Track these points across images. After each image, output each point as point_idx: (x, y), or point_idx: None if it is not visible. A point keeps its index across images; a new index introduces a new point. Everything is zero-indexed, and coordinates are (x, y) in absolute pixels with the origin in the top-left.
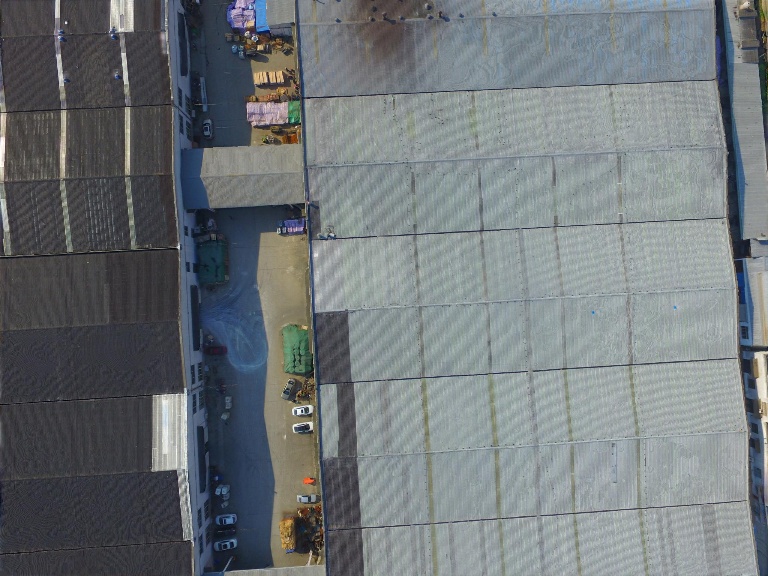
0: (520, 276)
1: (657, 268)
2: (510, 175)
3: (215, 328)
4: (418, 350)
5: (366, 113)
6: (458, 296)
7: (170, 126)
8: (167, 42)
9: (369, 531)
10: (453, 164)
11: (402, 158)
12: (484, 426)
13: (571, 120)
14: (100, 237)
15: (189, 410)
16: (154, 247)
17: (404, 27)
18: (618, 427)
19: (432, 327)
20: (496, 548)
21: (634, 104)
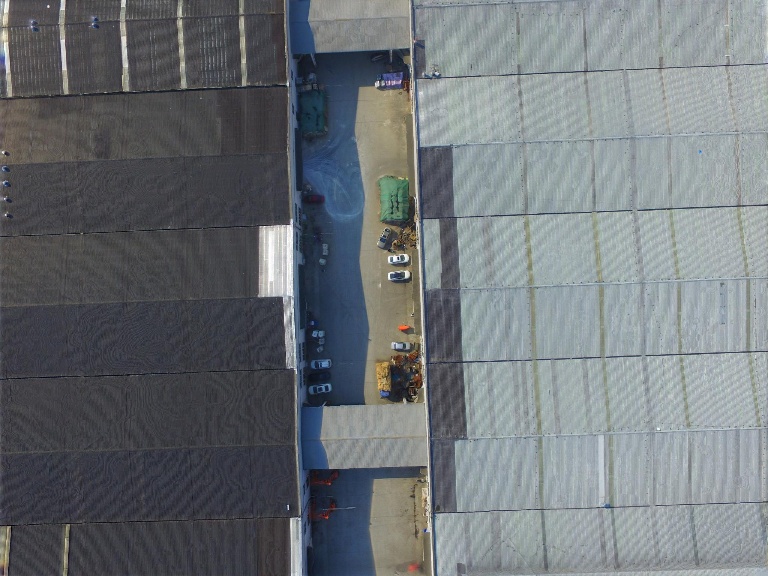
0: (625, 115)
1: (766, 109)
2: (615, 16)
3: (313, 178)
4: (521, 186)
5: None
6: (563, 133)
7: None
8: None
9: (470, 365)
10: (558, 5)
11: None
12: (588, 262)
13: None
14: (213, 74)
15: (294, 242)
16: (264, 84)
17: None
18: (727, 267)
19: (536, 163)
20: (600, 386)
21: None
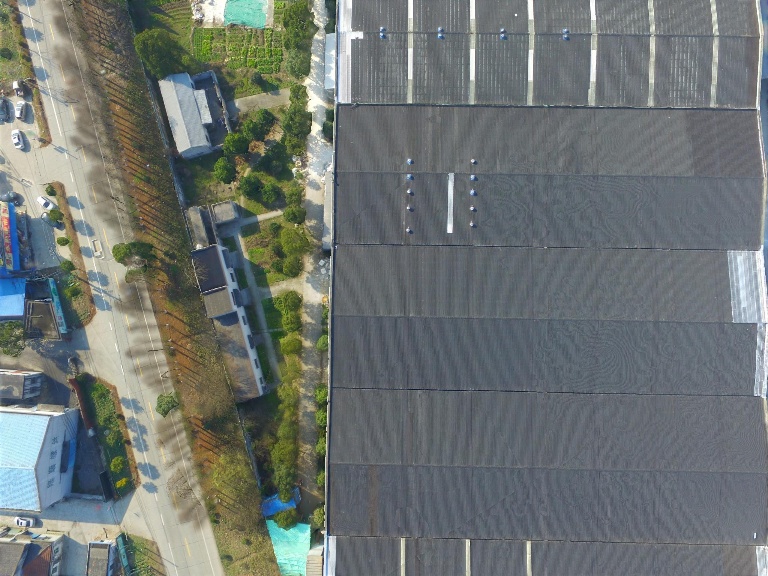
0: None
1: None
2: None
3: None
4: None
5: None
6: None
7: None
8: None
9: None
10: None
11: None
12: None
13: None
14: (682, 94)
15: None
16: (733, 107)
17: None
18: None
19: None
20: None
21: None
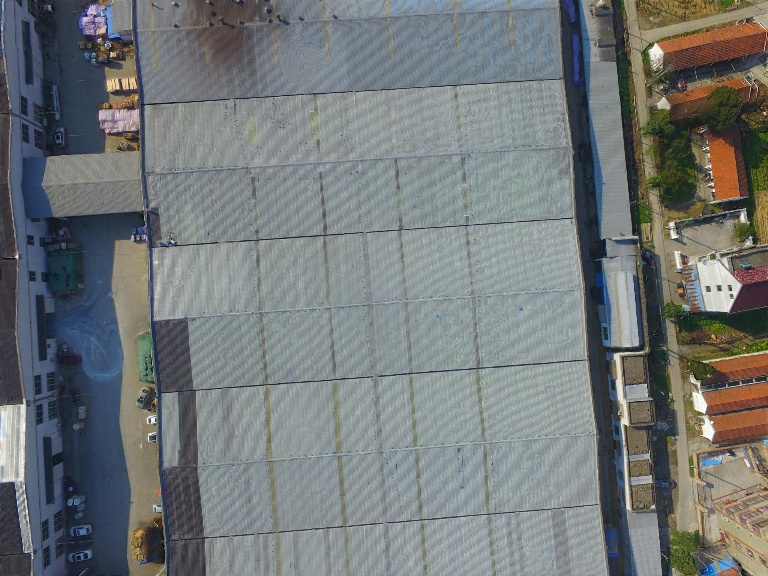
0: (363, 280)
1: (503, 270)
2: (352, 178)
3: (70, 337)
4: (260, 357)
5: (206, 119)
6: (299, 302)
7: (8, 135)
8: (3, 51)
9: (212, 541)
10: (294, 168)
11: (242, 163)
12: (327, 433)
13: (415, 122)
14: None
15: (30, 421)
16: None
17: (244, 31)
18: (464, 432)
19: (274, 333)
20: (341, 556)
21: (479, 105)
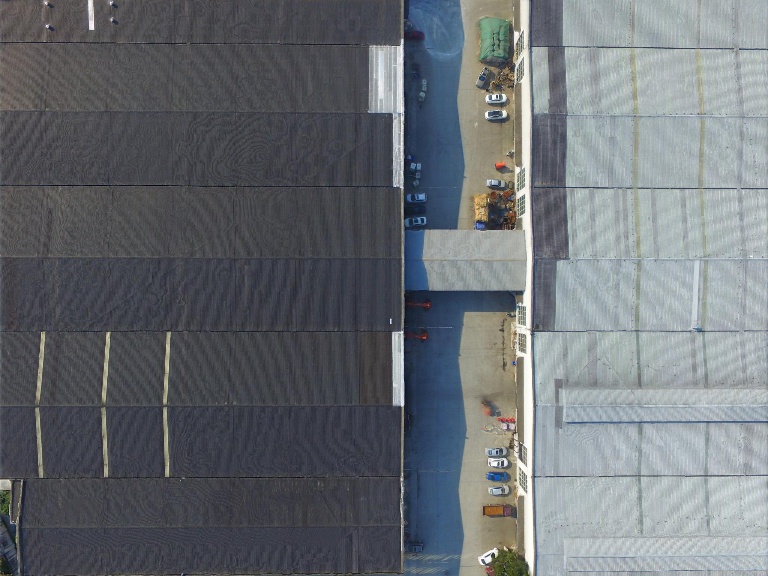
0: None
1: None
2: None
3: (413, 16)
4: (629, 19)
5: None
6: None
7: None
8: None
9: (573, 190)
10: None
11: None
12: (691, 95)
13: None
14: None
15: None
16: None
17: None
18: None
19: None
20: (697, 215)
21: None
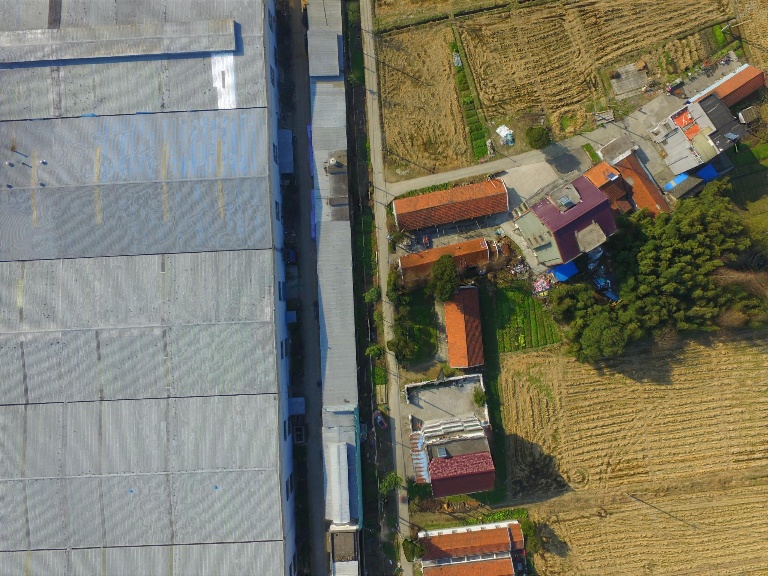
0: (59, 452)
1: (201, 446)
2: (53, 349)
3: None
4: None
5: None
6: None
7: None
8: None
9: None
10: None
11: None
12: None
13: (119, 292)
14: None
15: None
16: None
17: None
18: None
19: None
20: None
21: (185, 275)
